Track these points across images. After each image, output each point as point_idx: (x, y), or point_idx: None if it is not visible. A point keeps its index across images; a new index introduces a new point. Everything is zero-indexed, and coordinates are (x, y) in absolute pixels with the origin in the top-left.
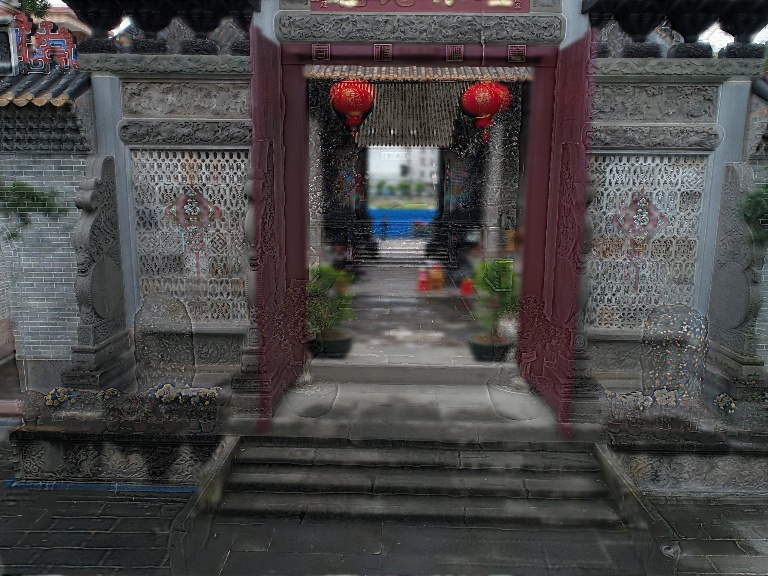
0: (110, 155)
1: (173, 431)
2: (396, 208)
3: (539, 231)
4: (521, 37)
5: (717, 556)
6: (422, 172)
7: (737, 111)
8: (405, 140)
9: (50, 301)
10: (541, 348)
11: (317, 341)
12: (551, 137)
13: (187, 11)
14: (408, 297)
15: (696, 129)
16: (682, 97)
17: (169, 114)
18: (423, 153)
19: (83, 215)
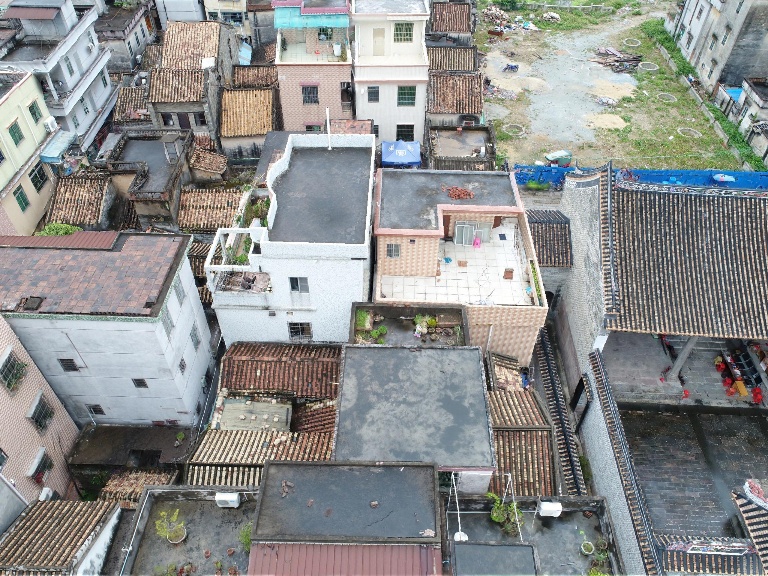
0: None
1: None
2: None
3: None
4: None
5: (719, 537)
6: None
7: None
8: None
9: None
10: None
11: None
12: None
13: None
14: None
15: None
16: None
17: None
18: None
19: None
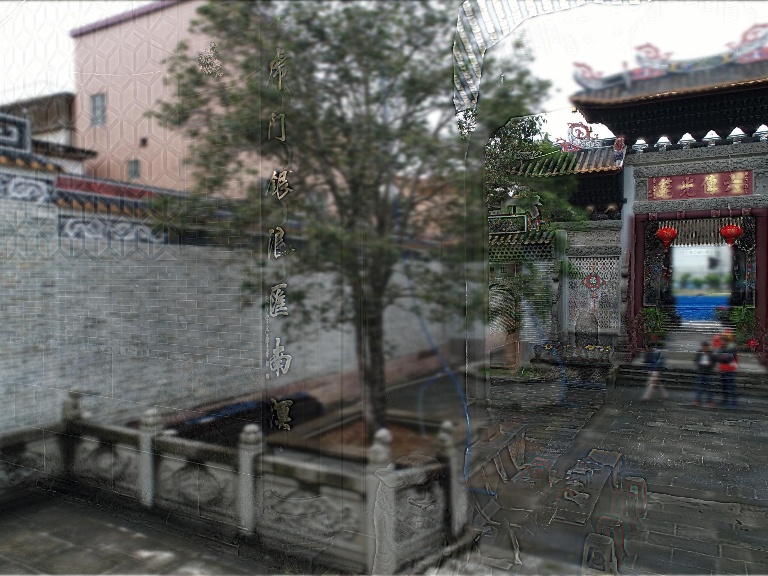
0: (561, 260)
1: (592, 362)
2: (699, 297)
3: (764, 289)
4: (748, 205)
5: None
6: (724, 265)
7: None
8: (706, 239)
9: (532, 318)
10: (760, 339)
11: (651, 333)
12: (767, 246)
13: (596, 205)
14: (703, 346)
15: None
16: None
17: (586, 243)
18: (724, 249)
19: (554, 283)
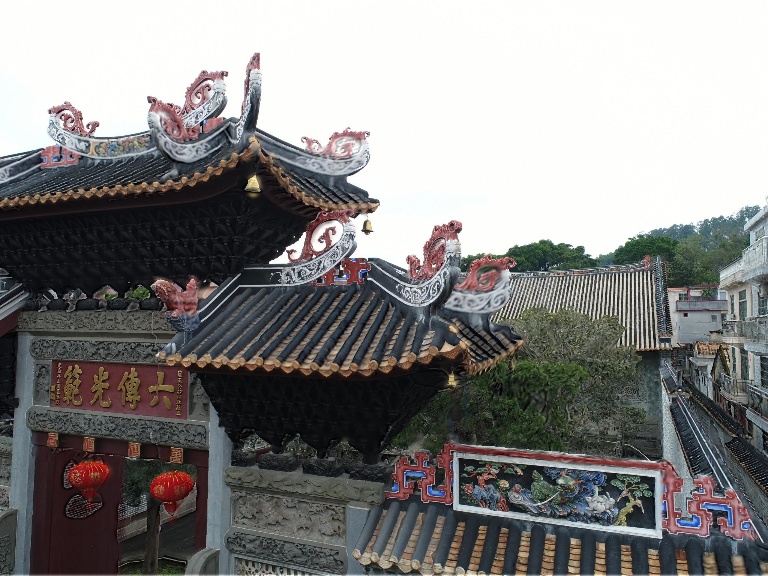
0: None
1: None
2: None
3: None
4: (178, 442)
5: None
6: None
7: (356, 540)
8: None
9: None
10: None
11: None
12: None
13: None
14: None
15: (324, 551)
16: (314, 513)
17: None
18: None
19: None
